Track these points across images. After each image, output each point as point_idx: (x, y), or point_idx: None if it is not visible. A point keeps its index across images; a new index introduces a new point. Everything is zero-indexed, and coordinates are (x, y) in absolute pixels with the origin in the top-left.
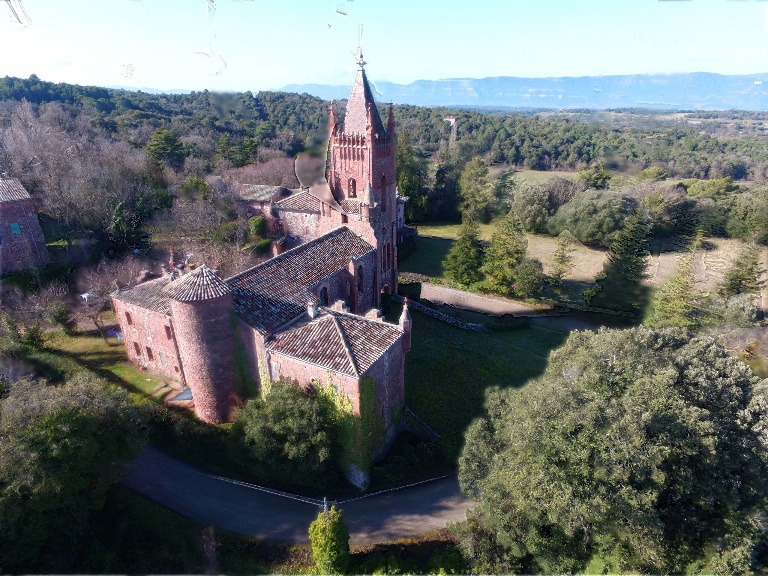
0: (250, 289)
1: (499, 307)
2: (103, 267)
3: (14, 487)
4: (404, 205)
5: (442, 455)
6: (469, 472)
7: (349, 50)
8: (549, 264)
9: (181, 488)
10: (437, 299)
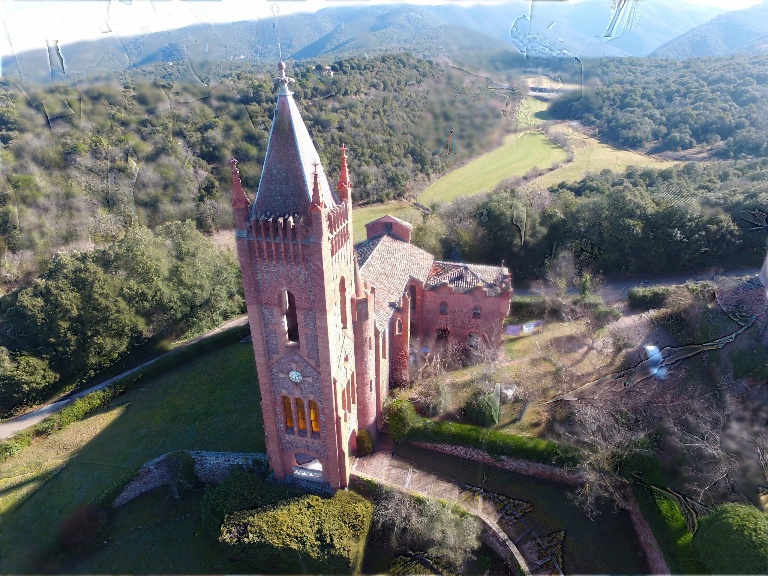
0: None
1: None
2: (756, 394)
3: None
4: None
5: None
6: None
7: None
8: None
9: None
10: None
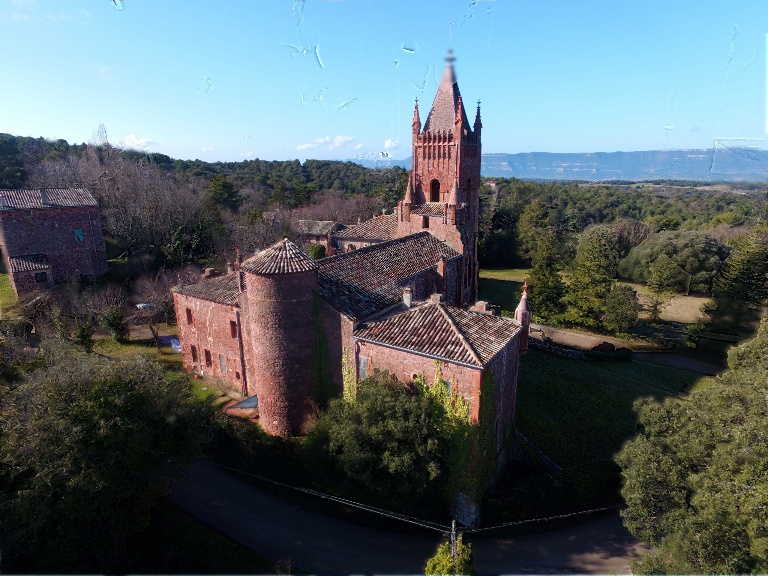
0: (334, 275)
1: (586, 341)
2: (160, 283)
3: (45, 475)
4: None
5: (573, 491)
6: (646, 501)
7: (415, 84)
8: (643, 294)
9: (242, 512)
10: None
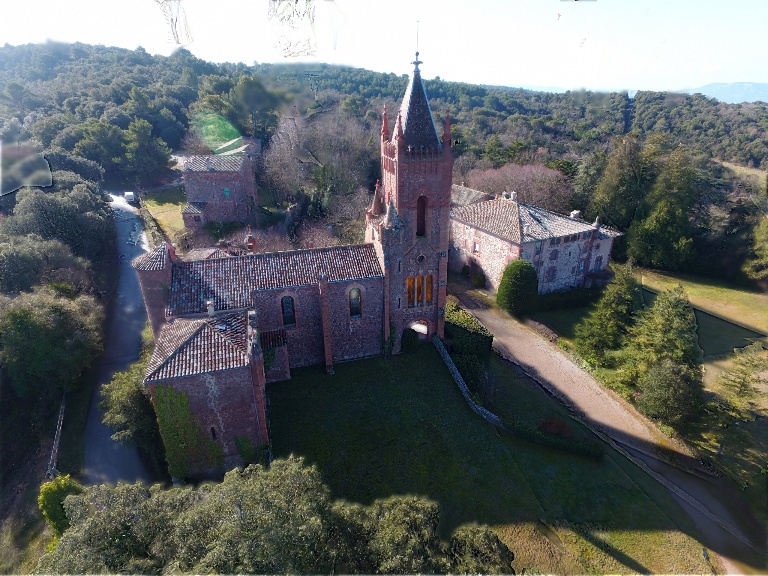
0: (202, 274)
1: (607, 414)
2: (276, 233)
3: None
4: (613, 242)
5: None
6: None
7: (572, 43)
8: (718, 387)
9: None
10: (536, 367)
